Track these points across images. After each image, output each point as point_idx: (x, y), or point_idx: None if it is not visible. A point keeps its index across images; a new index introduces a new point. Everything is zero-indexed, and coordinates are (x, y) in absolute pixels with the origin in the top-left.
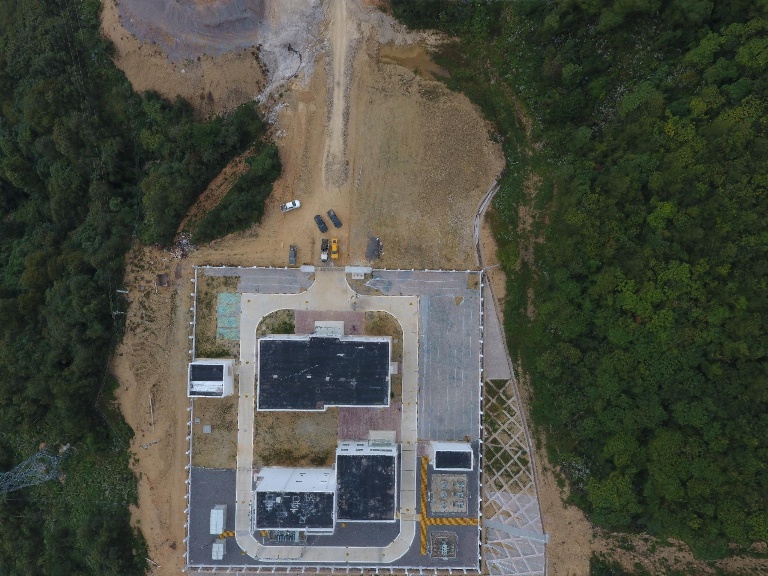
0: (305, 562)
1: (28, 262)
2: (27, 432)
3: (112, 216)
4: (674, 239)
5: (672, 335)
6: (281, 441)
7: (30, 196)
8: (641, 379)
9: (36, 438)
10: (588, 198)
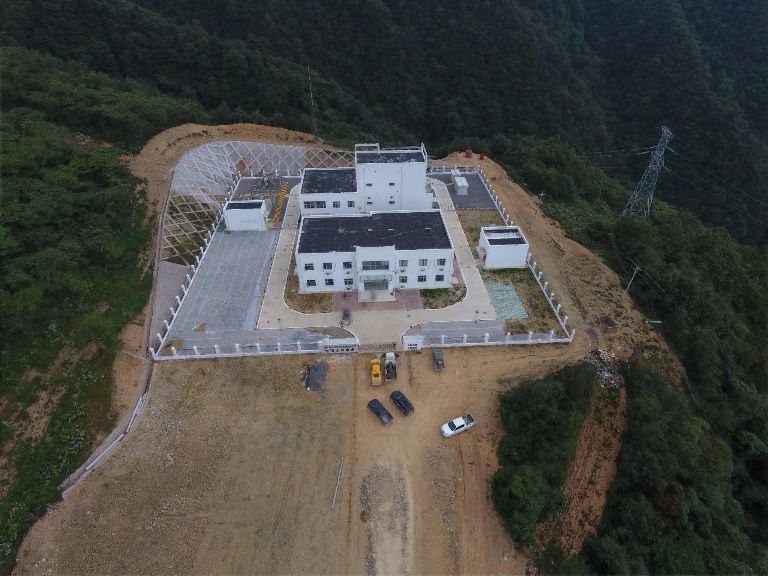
0: None
1: None
2: None
3: (742, 414)
4: None
5: None
6: None
7: None
8: None
9: None
10: None
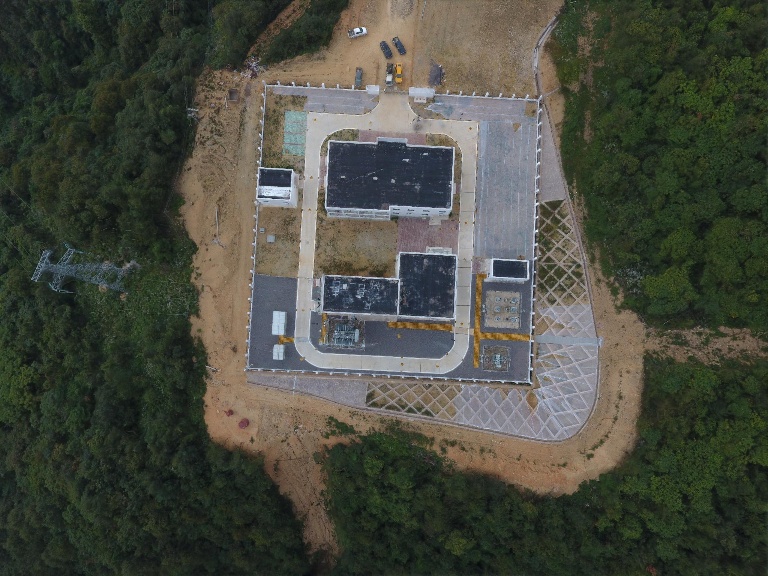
0: (361, 370)
1: (100, 87)
2: (96, 239)
3: (184, 42)
4: (736, 37)
5: (733, 125)
6: (342, 253)
7: (96, 46)
8: (701, 170)
9: (101, 255)
10: (650, 11)
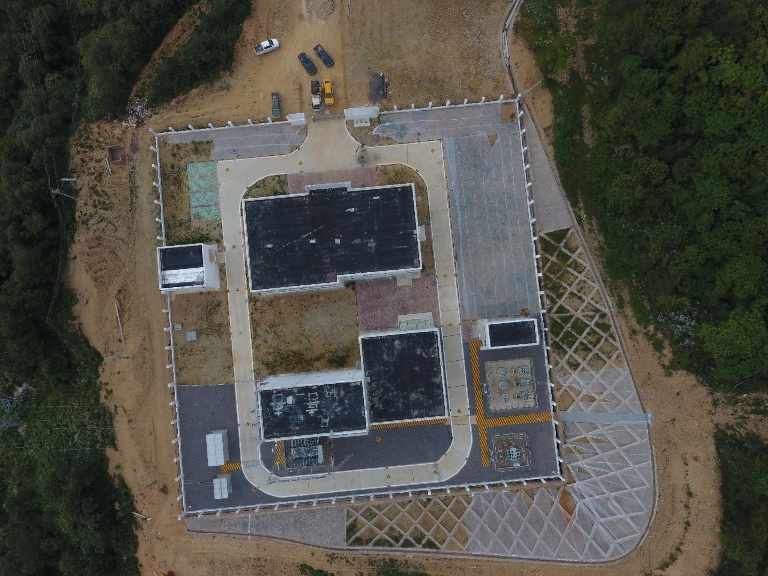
0: (335, 492)
1: None
2: None
3: (48, 93)
4: None
5: None
6: (287, 341)
7: None
8: (762, 171)
9: None
10: None
